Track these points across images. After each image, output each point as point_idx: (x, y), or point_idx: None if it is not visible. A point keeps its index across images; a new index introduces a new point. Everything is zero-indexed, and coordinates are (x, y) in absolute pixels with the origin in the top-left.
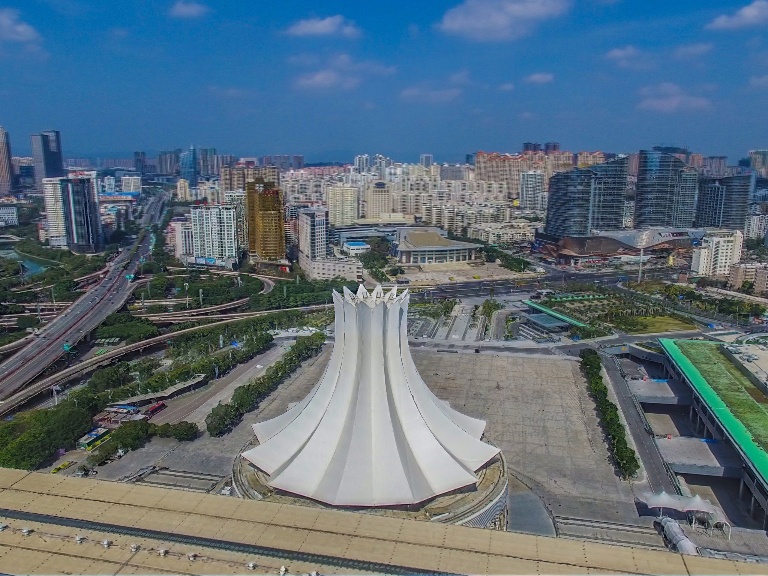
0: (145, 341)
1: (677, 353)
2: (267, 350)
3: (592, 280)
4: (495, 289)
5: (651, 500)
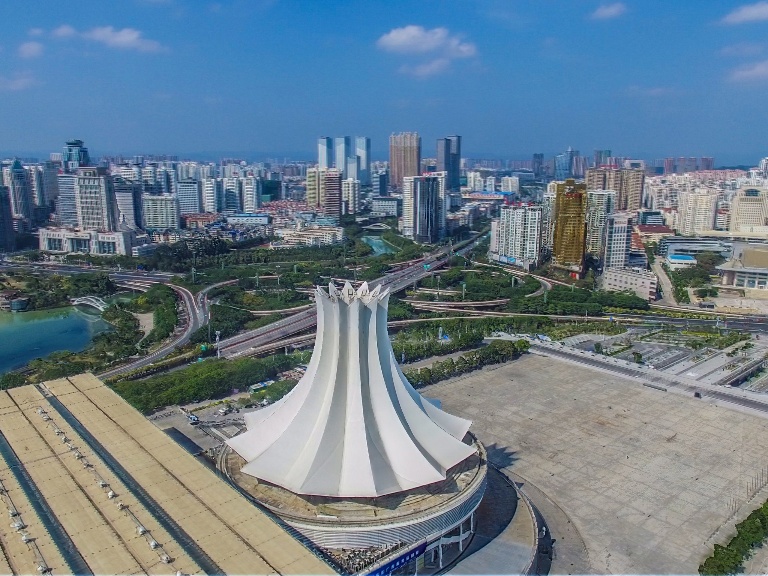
0: (390, 322)
1: None
2: (472, 348)
3: None
4: None
5: None
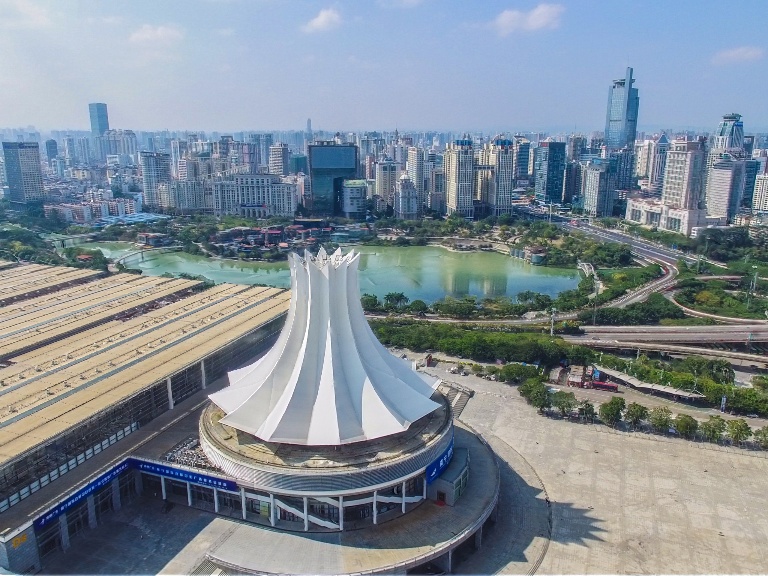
0: None
1: None
2: None
3: None
4: None
5: None
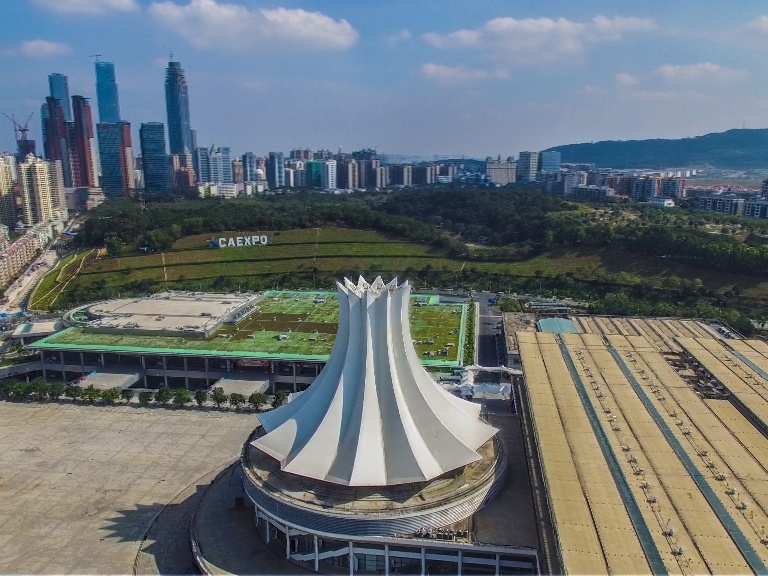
0: None
1: (79, 346)
2: None
3: None
4: None
5: None
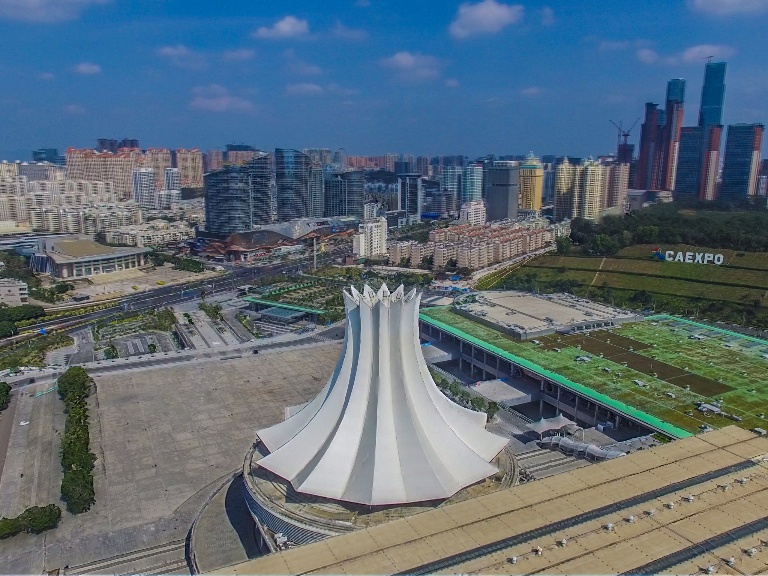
0: None
1: (430, 319)
2: (8, 403)
3: (280, 271)
4: (191, 292)
5: (537, 428)
